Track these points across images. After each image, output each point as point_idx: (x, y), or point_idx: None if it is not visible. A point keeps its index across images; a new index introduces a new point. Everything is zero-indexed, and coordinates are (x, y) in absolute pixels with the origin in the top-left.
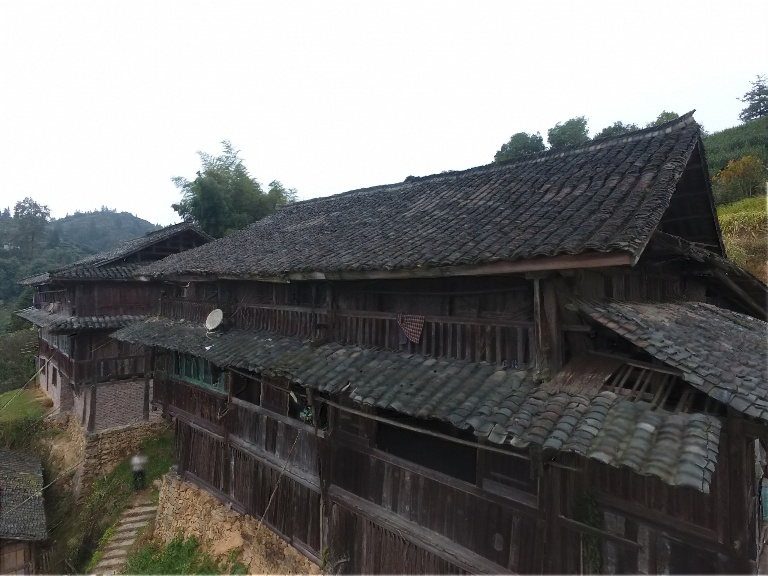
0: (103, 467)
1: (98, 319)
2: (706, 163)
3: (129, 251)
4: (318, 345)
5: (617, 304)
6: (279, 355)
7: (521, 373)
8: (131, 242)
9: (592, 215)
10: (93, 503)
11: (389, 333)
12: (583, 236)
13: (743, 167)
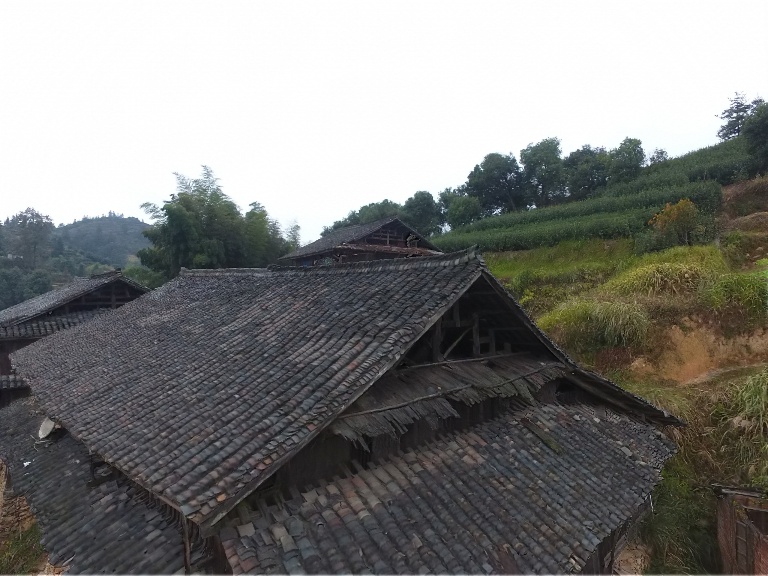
0: (21, 524)
1: (15, 377)
2: (503, 290)
3: (52, 306)
4: (98, 483)
5: (317, 492)
6: (63, 491)
7: (196, 575)
8: (75, 284)
9: (271, 414)
10: (2, 565)
11: None
12: (210, 466)
13: (678, 212)
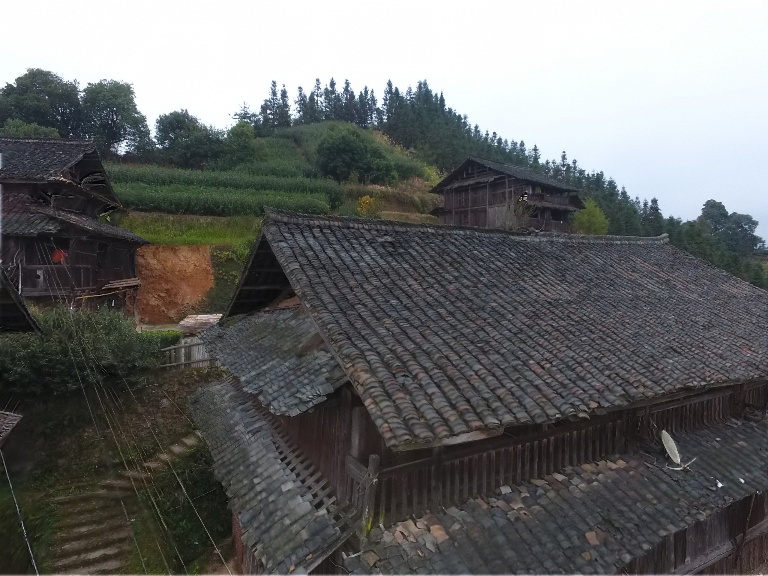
0: None
1: None
2: None
3: None
4: None
5: None
6: None
7: None
8: None
9: None
10: None
11: (760, 395)
12: None
13: None
